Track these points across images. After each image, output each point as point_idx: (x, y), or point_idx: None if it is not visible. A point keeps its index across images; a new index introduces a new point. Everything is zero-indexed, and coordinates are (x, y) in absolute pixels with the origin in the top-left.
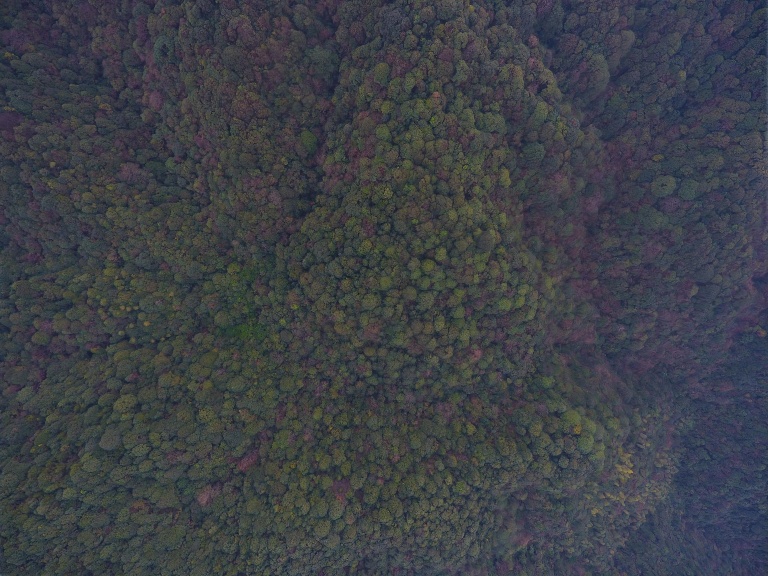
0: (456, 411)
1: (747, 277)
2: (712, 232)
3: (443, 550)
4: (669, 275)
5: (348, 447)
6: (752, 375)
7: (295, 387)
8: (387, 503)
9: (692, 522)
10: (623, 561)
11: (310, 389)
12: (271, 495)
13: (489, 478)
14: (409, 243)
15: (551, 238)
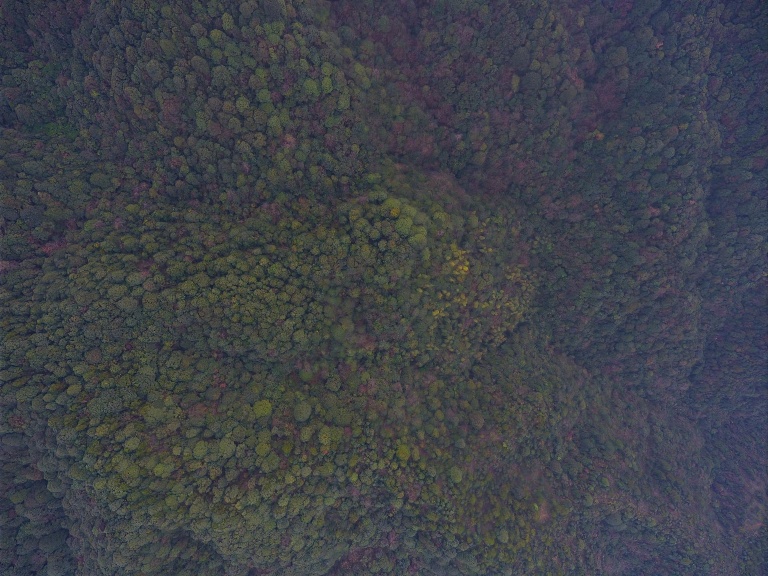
0: (284, 212)
1: (567, 65)
2: (516, 6)
3: (260, 329)
4: (486, 63)
5: (161, 235)
6: (595, 182)
7: (111, 185)
8: (192, 276)
9: (560, 347)
10: (478, 372)
11: (127, 188)
12: (69, 267)
13: (310, 264)
14: (190, 7)
15: (368, 33)
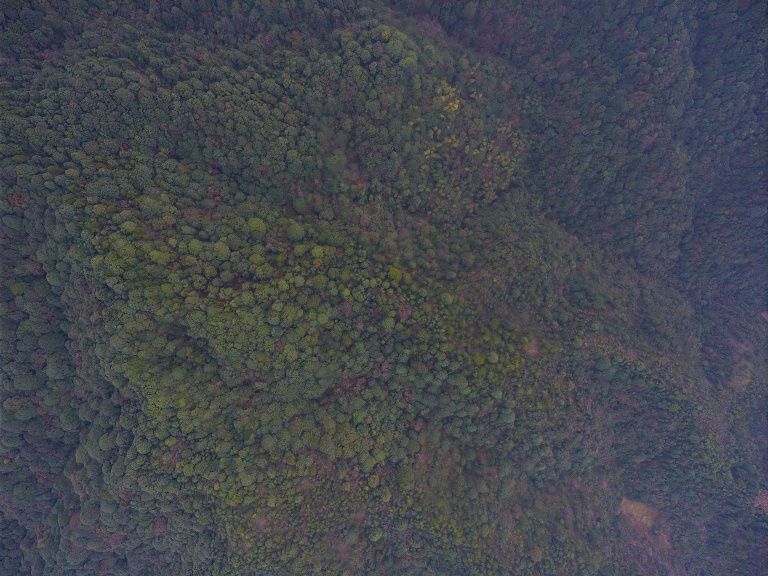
0: (278, 44)
1: None
2: None
3: (254, 140)
4: None
5: None
6: (584, 35)
7: (108, 8)
8: (188, 80)
9: (551, 212)
10: (470, 222)
11: (124, 12)
12: None
13: (302, 85)
14: None
15: None
